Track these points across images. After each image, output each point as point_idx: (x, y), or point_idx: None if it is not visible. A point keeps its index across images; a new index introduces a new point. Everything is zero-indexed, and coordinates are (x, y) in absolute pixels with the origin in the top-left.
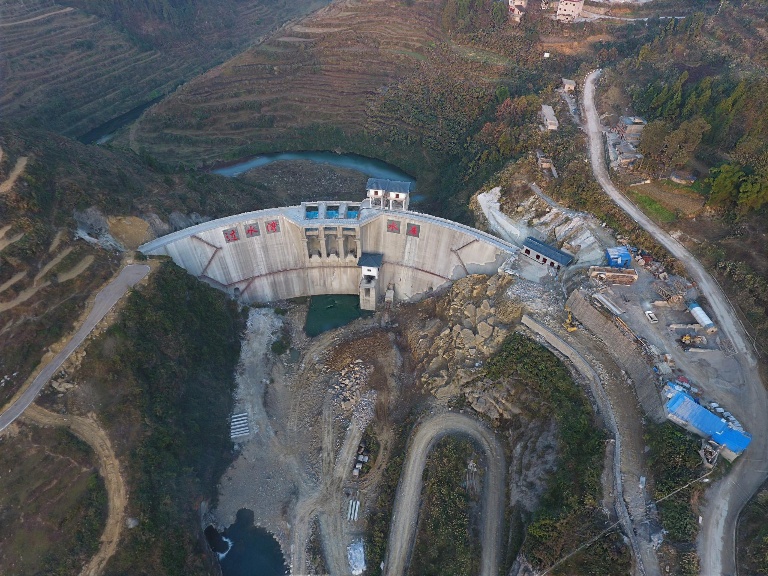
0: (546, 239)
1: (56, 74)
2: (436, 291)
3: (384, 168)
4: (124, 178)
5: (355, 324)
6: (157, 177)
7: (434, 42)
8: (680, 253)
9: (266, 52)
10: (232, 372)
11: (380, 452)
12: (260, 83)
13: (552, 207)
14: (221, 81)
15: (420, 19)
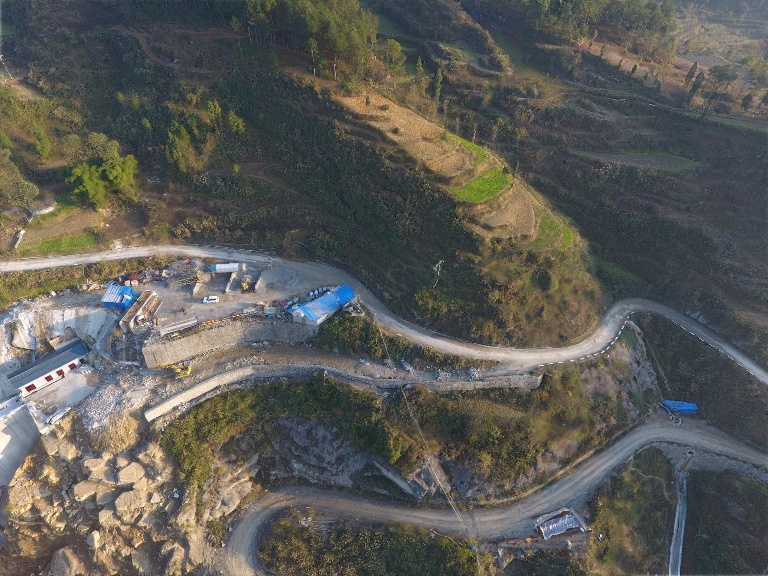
0: (19, 362)
1: None
2: None
3: None
4: None
5: None
6: None
7: None
8: (144, 252)
9: None
10: None
11: None
12: None
13: None
14: None
15: None
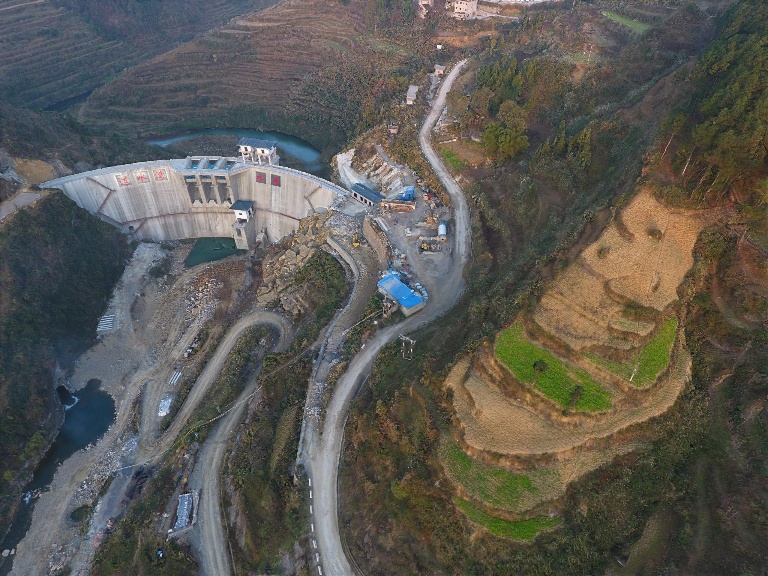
0: (375, 187)
1: (20, 57)
2: None
3: (298, 144)
4: (38, 132)
5: (227, 258)
6: (75, 136)
7: (358, 36)
8: (454, 191)
9: (207, 42)
10: (112, 287)
11: (208, 340)
12: (199, 69)
13: (384, 162)
14: (164, 66)
15: (352, 17)
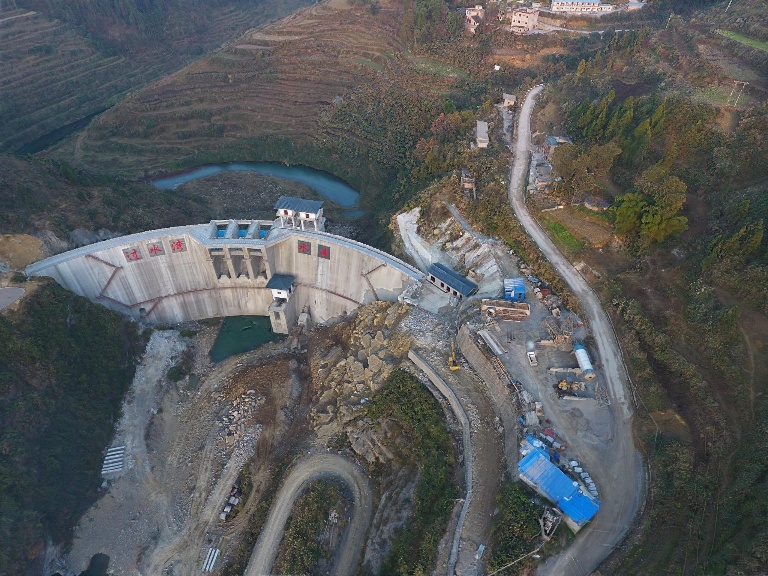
0: (456, 265)
1: (8, 79)
2: (350, 315)
3: (331, 181)
4: (25, 193)
5: (263, 349)
6: (71, 190)
7: (393, 52)
8: (579, 287)
9: (221, 60)
10: (120, 400)
11: (251, 494)
12: (213, 91)
13: (464, 231)
14: (173, 89)
15: (383, 28)
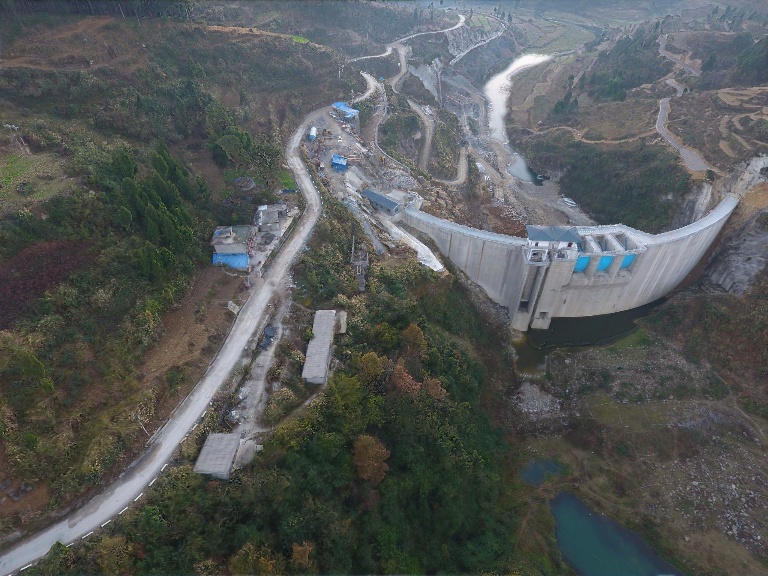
0: None
1: None
2: None
3: None
4: None
5: None
6: None
7: None
8: (294, 159)
9: None
10: (600, 223)
11: None
12: None
13: None
14: None
15: None
